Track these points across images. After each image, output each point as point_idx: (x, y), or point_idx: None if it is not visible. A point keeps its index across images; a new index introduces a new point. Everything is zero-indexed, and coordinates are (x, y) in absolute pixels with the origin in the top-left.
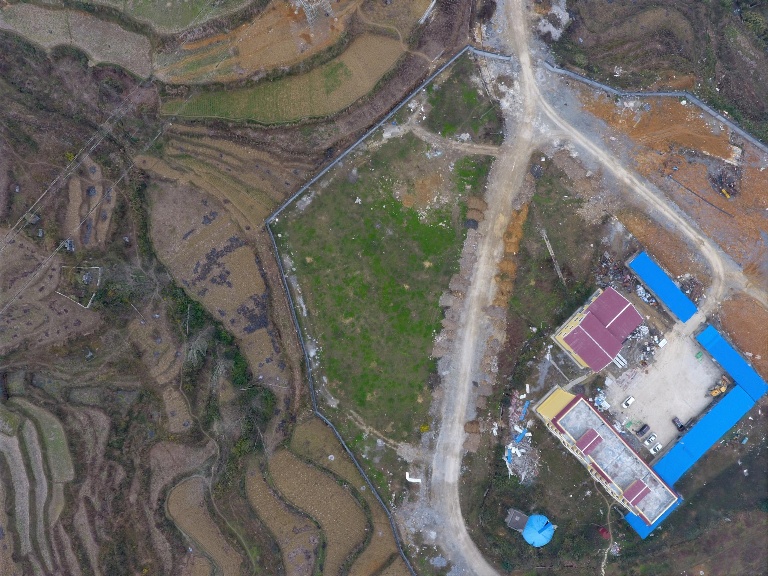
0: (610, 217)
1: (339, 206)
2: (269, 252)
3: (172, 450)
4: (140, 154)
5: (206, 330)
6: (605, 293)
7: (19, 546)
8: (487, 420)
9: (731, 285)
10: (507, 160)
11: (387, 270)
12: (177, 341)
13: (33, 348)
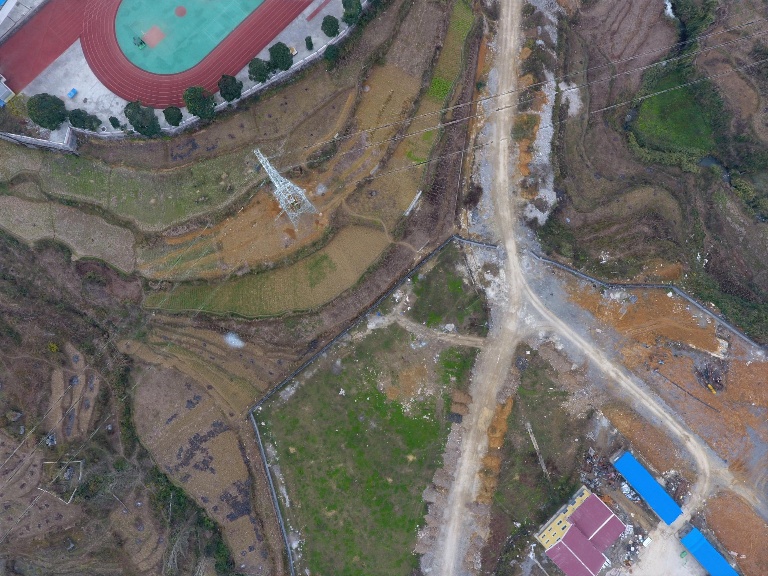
0: (595, 412)
1: (323, 397)
2: (252, 440)
3: None
4: (124, 339)
5: (188, 523)
6: (589, 500)
7: None
8: None
9: (716, 482)
10: (492, 352)
11: (370, 463)
12: (159, 528)
13: (14, 541)
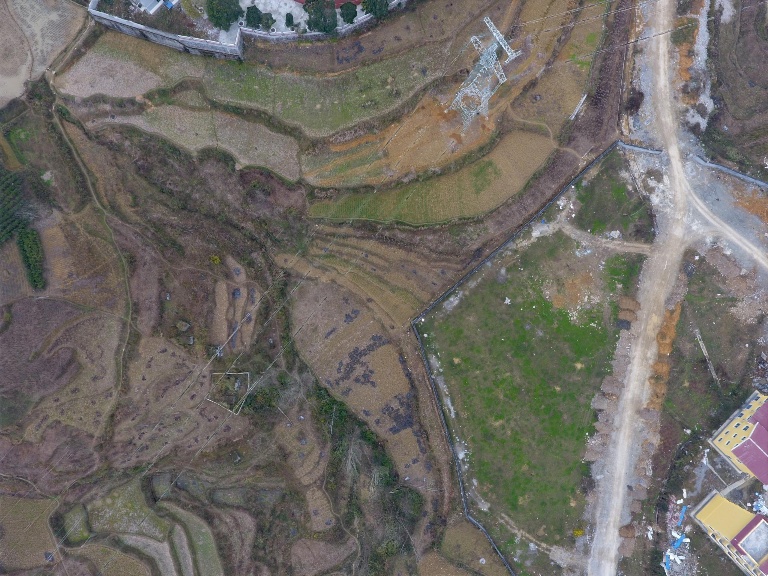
0: (766, 316)
1: (488, 307)
2: (414, 352)
3: (313, 547)
4: (281, 253)
5: (355, 434)
6: None
7: None
8: (641, 524)
9: None
10: (659, 258)
11: (538, 372)
12: (321, 442)
13: (182, 454)
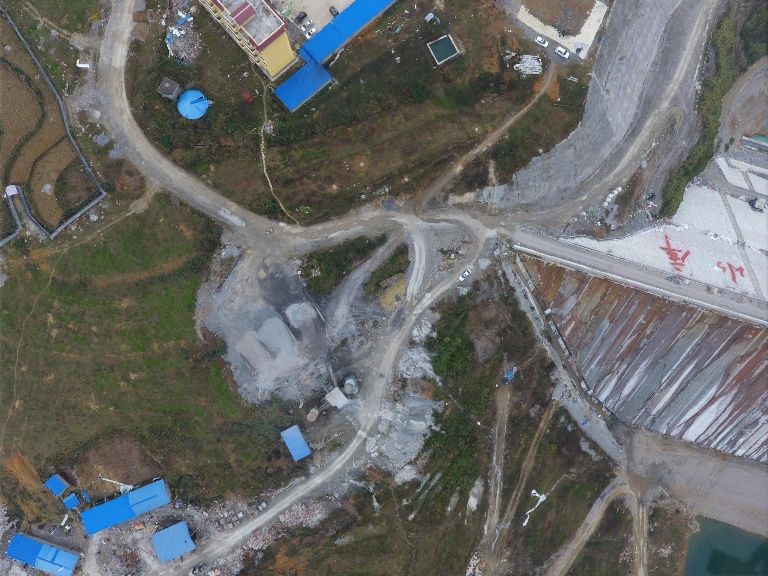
0: None
1: None
2: None
3: None
4: None
5: None
6: None
7: None
8: (157, 12)
9: None
10: None
11: None
12: None
13: None
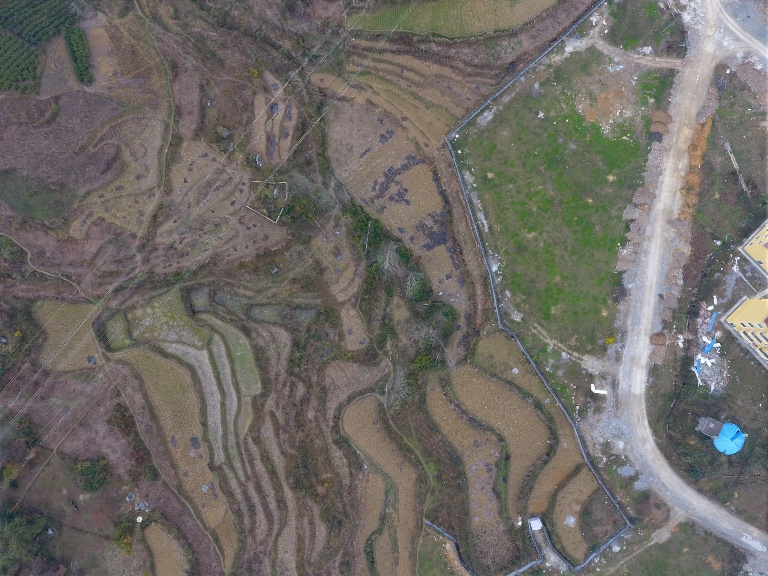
0: None
1: (521, 121)
2: (448, 169)
3: (346, 369)
4: (318, 72)
5: (391, 245)
6: None
7: (213, 456)
8: (672, 332)
9: None
10: (691, 73)
11: (570, 184)
12: (356, 259)
13: (221, 263)
